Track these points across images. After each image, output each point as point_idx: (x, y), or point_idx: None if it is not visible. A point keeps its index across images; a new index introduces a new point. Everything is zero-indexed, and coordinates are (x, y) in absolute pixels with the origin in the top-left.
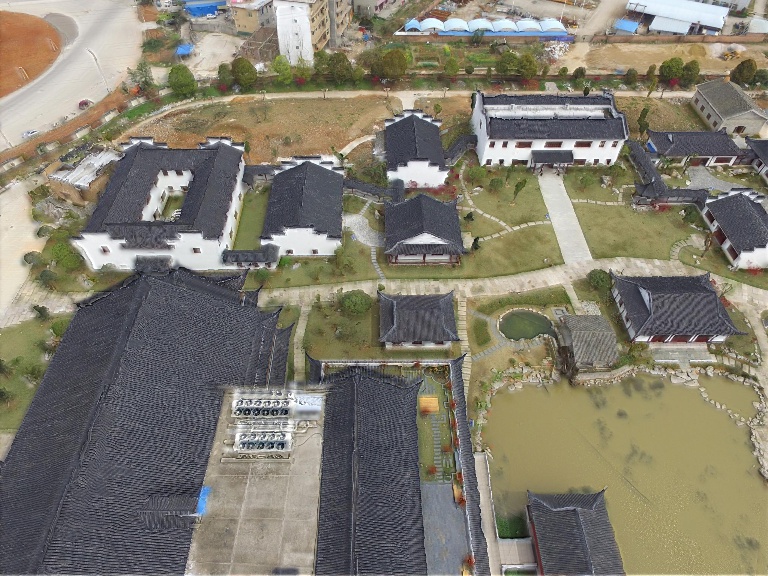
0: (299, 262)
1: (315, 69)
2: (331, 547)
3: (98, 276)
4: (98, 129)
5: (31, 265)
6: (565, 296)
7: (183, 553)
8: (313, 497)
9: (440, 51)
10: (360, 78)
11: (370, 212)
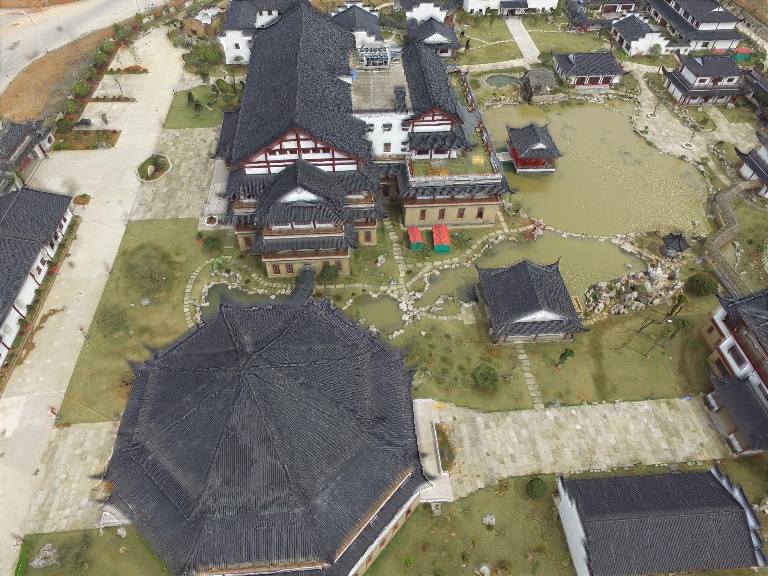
0: None
1: None
2: None
3: None
4: (197, 3)
5: (183, 66)
6: (525, 69)
7: (349, 94)
8: (404, 81)
9: None
10: None
11: (397, 38)
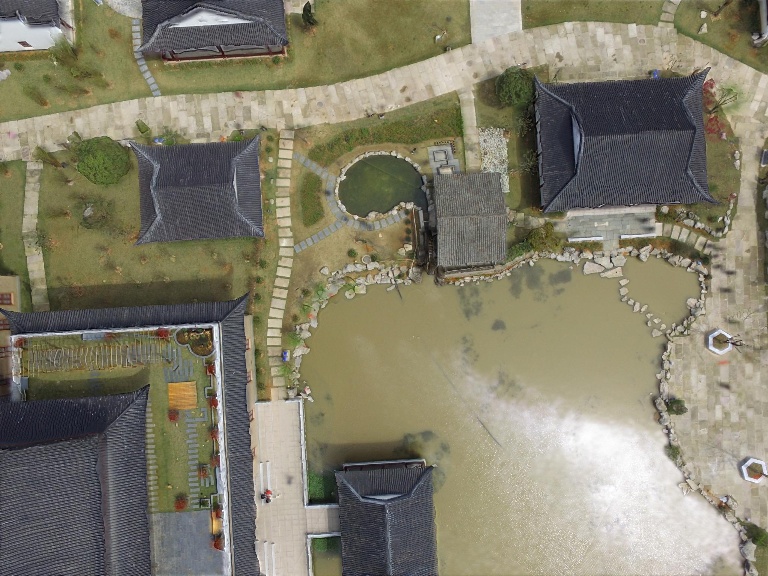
0: (5, 67)
1: None
2: None
3: None
4: None
5: None
6: (455, 121)
7: None
8: None
9: None
10: None
11: None
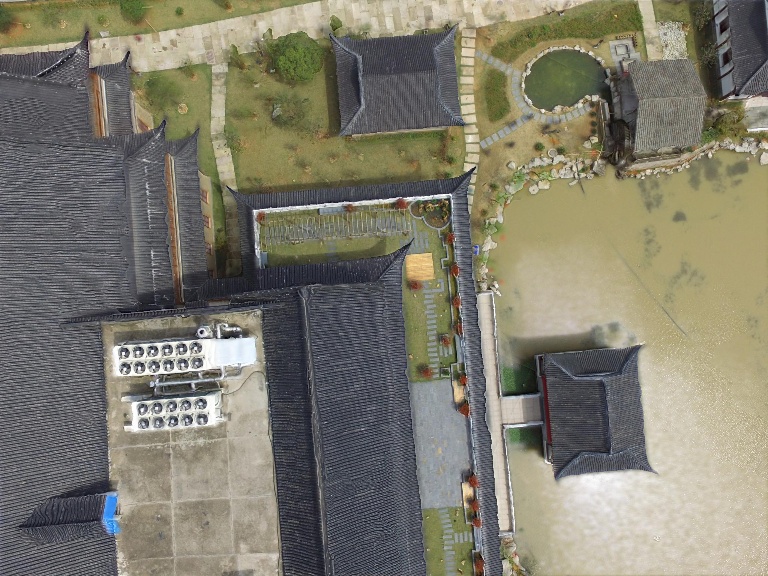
0: None
1: None
2: (297, 536)
3: None
4: None
5: None
6: (636, 15)
7: (109, 552)
8: (265, 465)
9: None
10: None
11: None
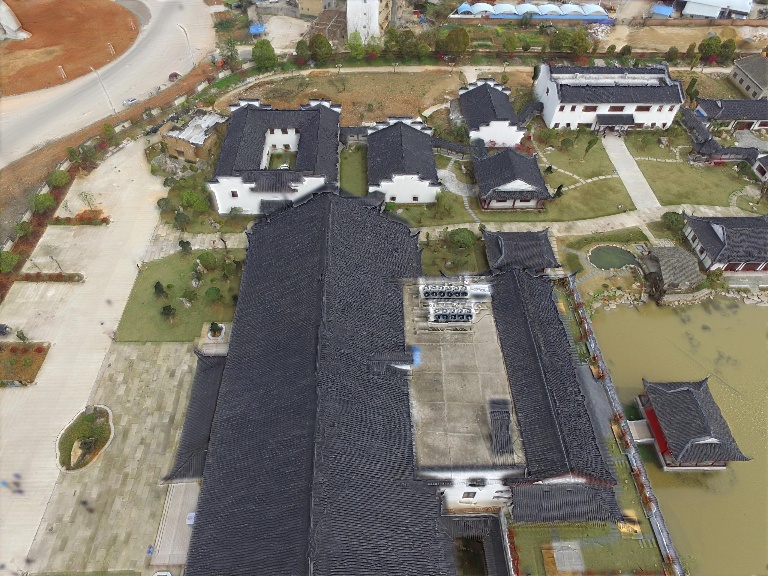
0: (401, 208)
1: (384, 46)
2: (525, 389)
3: (223, 220)
4: (192, 98)
5: (159, 211)
6: (643, 235)
7: (405, 395)
8: (498, 358)
9: (492, 32)
10: (426, 54)
11: (456, 168)
